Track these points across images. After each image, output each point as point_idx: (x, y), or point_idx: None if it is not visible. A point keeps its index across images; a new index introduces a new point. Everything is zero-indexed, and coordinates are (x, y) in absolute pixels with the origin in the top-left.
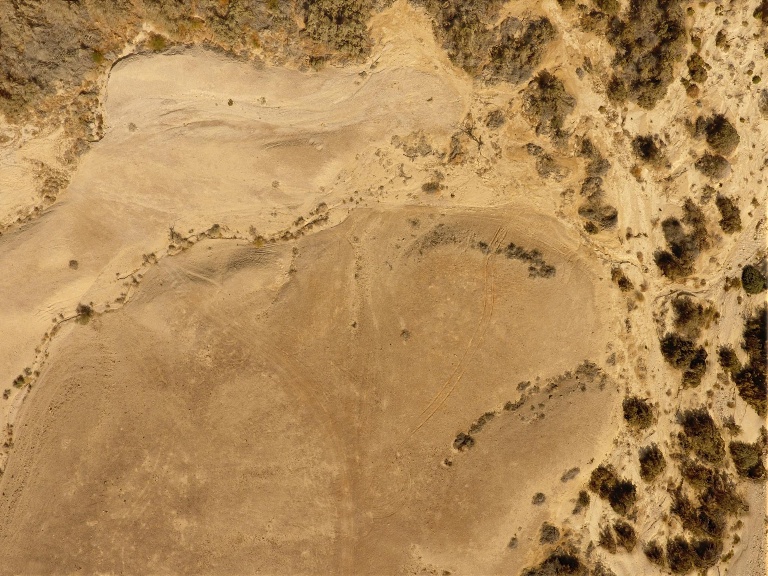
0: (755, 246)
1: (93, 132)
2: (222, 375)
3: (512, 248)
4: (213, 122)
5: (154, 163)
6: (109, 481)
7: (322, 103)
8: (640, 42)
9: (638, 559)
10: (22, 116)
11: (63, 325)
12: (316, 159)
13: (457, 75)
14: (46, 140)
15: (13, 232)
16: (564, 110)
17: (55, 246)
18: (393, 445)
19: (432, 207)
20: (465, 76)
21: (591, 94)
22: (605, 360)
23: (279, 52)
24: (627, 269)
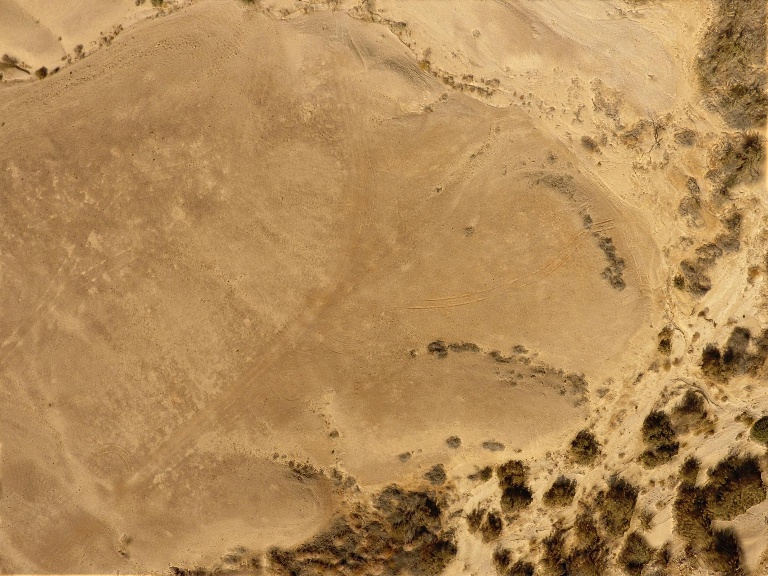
0: None
1: None
2: (308, 135)
3: (609, 241)
4: None
5: None
6: (155, 135)
7: (567, 4)
8: None
9: (484, 554)
10: None
11: None
12: (525, 41)
13: (688, 77)
14: None
15: None
16: (744, 176)
17: None
18: (386, 303)
19: (576, 158)
20: (693, 83)
21: None
22: (598, 388)
23: None
24: (677, 337)
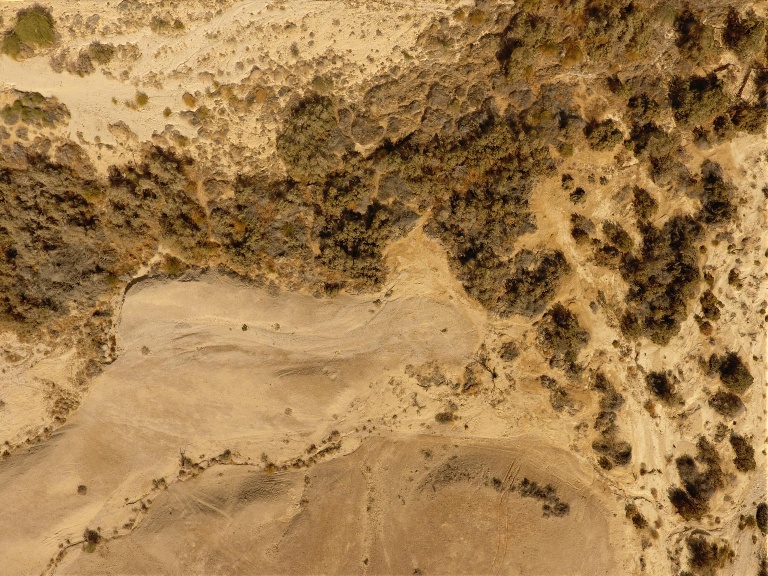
0: None
1: (106, 354)
2: None
3: (526, 485)
4: (227, 347)
5: (166, 388)
6: None
7: (336, 330)
8: (653, 278)
9: None
10: (35, 336)
11: (69, 551)
12: (329, 389)
13: (471, 305)
14: (58, 360)
15: (22, 453)
16: (578, 345)
17: (64, 472)
18: None
19: (445, 437)
20: (479, 307)
21: (605, 328)
22: None
23: (294, 277)
24: (641, 505)
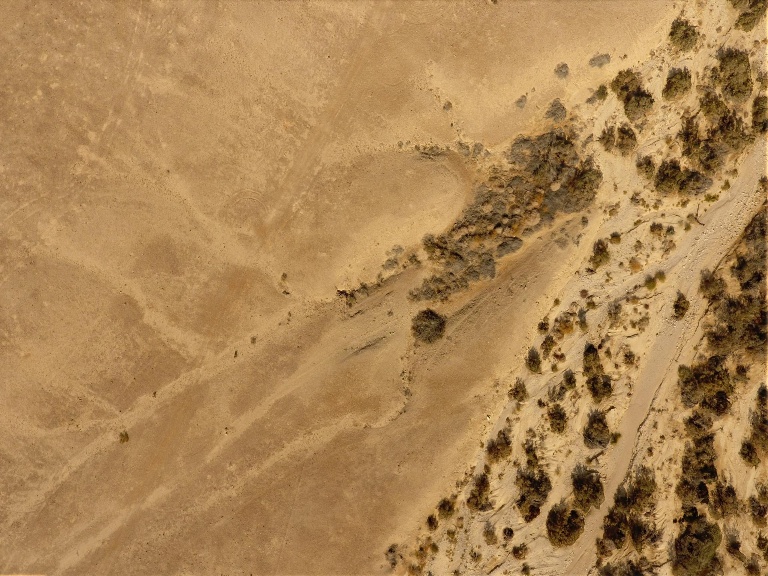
0: None
1: None
2: None
3: None
4: None
5: None
6: None
7: None
8: None
9: (628, 168)
10: None
11: None
12: None
13: None
14: None
15: None
16: None
17: None
18: None
19: None
20: None
21: None
22: None
23: None
24: None
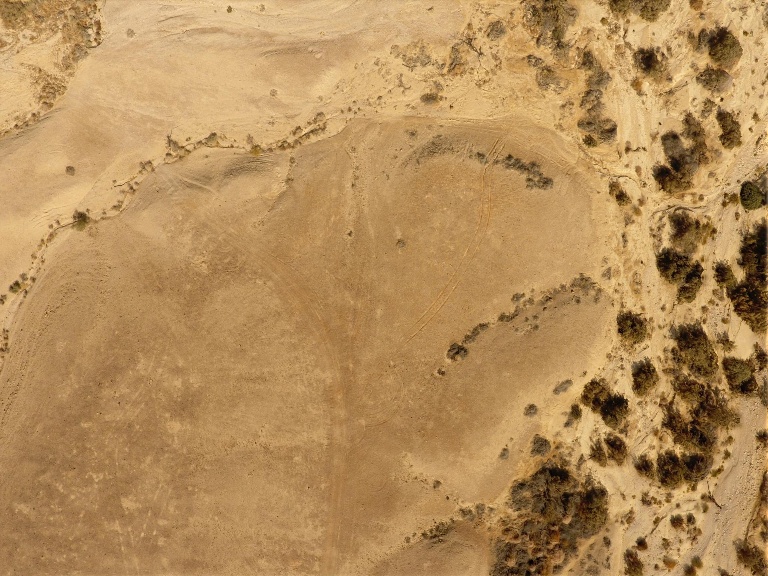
0: (754, 162)
1: (91, 38)
2: (217, 281)
3: (510, 159)
4: (212, 29)
5: (152, 70)
6: (104, 383)
7: (322, 11)
8: None
9: (628, 473)
10: (20, 21)
11: (59, 231)
12: (315, 67)
13: None
14: (44, 45)
15: (10, 138)
16: (566, 21)
17: (52, 151)
18: (387, 354)
19: (430, 118)
20: None
21: (593, 5)
22: (600, 274)
23: None
24: (625, 183)
